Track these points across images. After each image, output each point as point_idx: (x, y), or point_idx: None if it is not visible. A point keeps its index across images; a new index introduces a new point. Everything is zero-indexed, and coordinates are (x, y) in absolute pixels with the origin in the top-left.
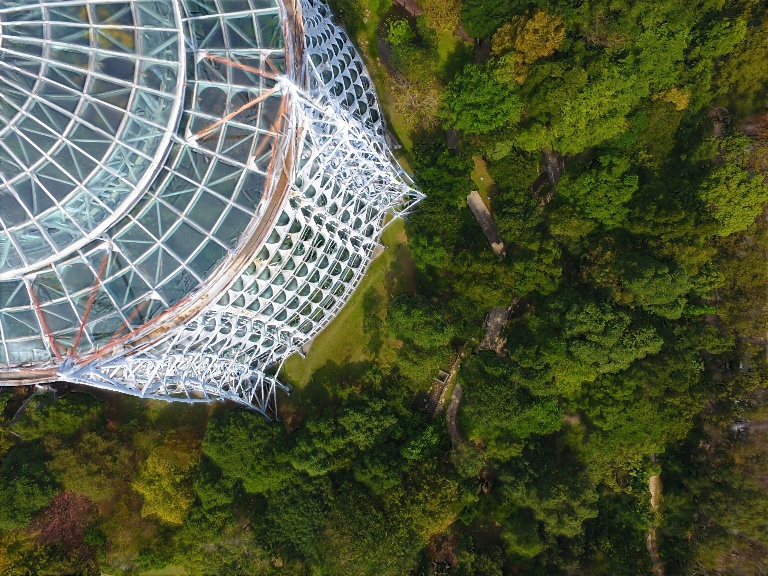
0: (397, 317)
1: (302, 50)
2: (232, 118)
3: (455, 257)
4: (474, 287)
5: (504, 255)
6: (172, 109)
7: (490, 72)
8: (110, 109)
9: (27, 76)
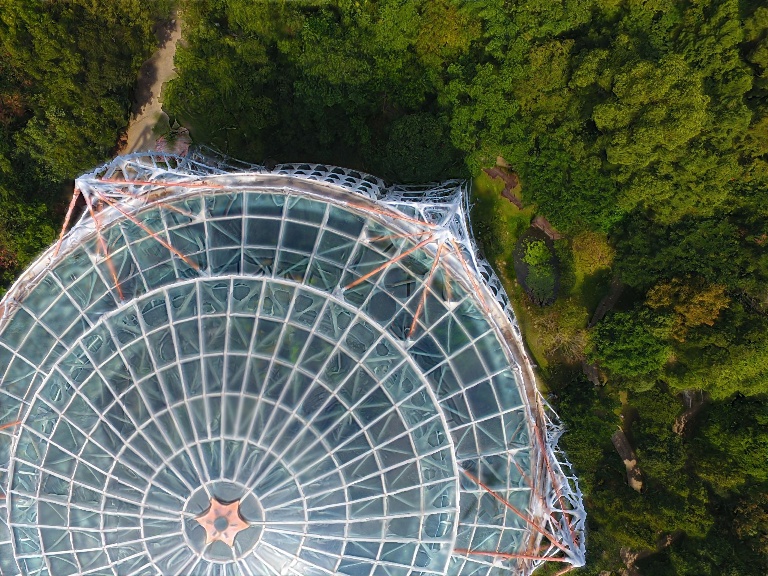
0: (550, 568)
1: (545, 444)
2: (480, 518)
3: (595, 487)
4: (625, 535)
5: (636, 472)
6: (449, 554)
7: (643, 322)
8: (397, 568)
9: (330, 556)
